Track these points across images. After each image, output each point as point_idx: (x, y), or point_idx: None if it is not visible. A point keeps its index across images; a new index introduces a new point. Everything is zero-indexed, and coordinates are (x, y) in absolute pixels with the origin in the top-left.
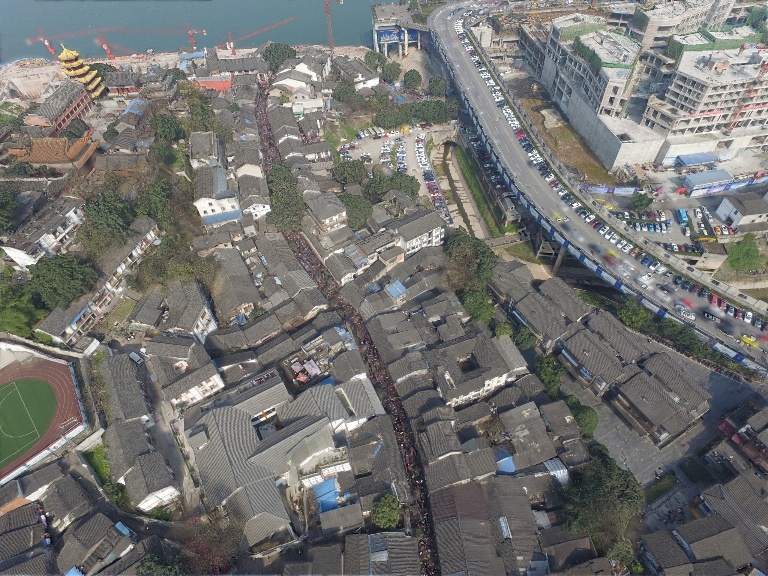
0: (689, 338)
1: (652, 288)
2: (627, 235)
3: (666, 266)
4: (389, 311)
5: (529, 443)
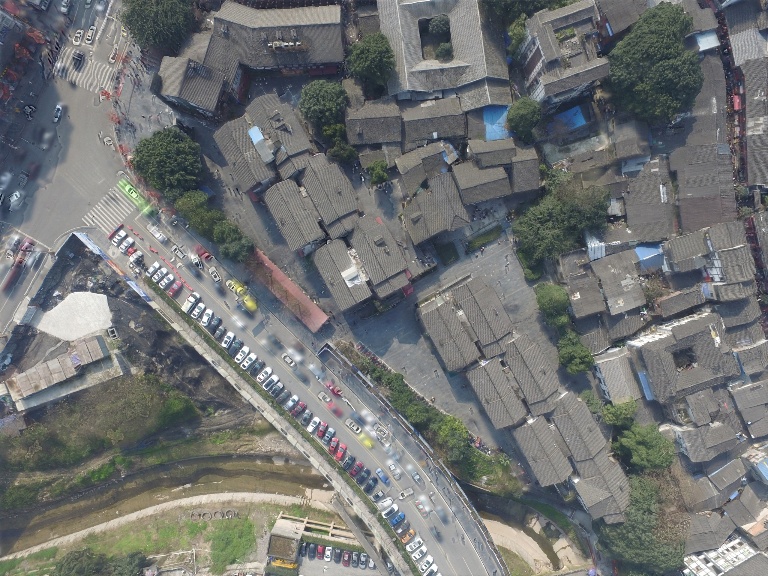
0: (404, 394)
1: (407, 474)
2: (406, 570)
3: (375, 510)
4: (766, 441)
5: (620, 273)
